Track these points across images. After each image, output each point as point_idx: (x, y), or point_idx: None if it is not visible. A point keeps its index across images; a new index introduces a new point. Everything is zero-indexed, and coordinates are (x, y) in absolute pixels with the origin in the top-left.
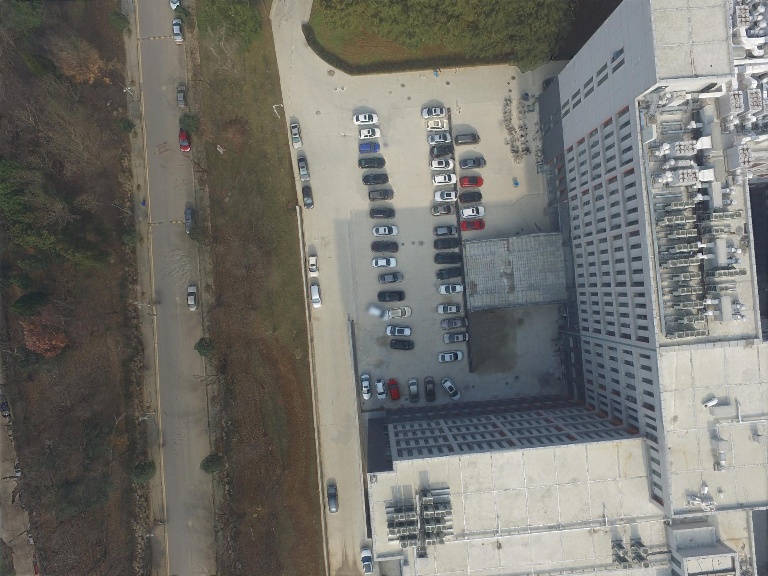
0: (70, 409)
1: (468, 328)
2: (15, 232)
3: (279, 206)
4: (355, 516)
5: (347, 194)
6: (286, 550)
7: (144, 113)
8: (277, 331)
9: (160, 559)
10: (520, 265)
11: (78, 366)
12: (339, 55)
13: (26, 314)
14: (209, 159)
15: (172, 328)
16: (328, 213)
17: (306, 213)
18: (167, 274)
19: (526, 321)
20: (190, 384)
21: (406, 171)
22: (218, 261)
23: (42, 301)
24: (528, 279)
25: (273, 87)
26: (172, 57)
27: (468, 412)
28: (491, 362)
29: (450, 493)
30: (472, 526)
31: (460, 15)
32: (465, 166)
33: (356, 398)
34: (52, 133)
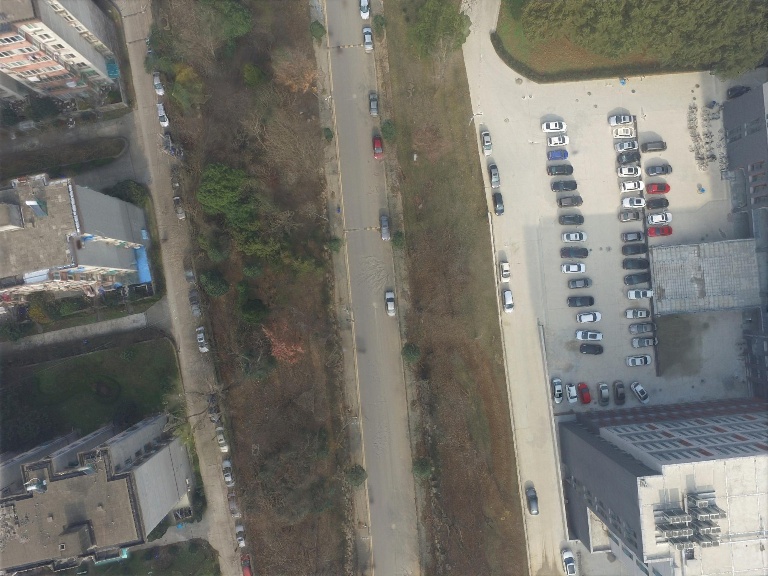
0: (314, 415)
1: (655, 332)
2: (240, 240)
3: (471, 213)
4: (554, 518)
5: (536, 201)
6: (493, 552)
7: (336, 121)
8: (477, 336)
9: (365, 561)
10: (712, 271)
11: (281, 371)
12: (527, 63)
13: (253, 321)
14: (401, 166)
15: (370, 333)
16: (517, 219)
17: (496, 219)
18: (363, 280)
19: (711, 325)
20: (390, 389)
21: (593, 178)
22: (414, 267)
23: (265, 308)
24: (721, 284)
25: (462, 95)
26: (362, 65)
27: (667, 415)
28: (677, 366)
29: (715, 496)
30: (736, 528)
31: (677, 26)
32: (653, 173)
33: (551, 402)
34: (277, 142)
